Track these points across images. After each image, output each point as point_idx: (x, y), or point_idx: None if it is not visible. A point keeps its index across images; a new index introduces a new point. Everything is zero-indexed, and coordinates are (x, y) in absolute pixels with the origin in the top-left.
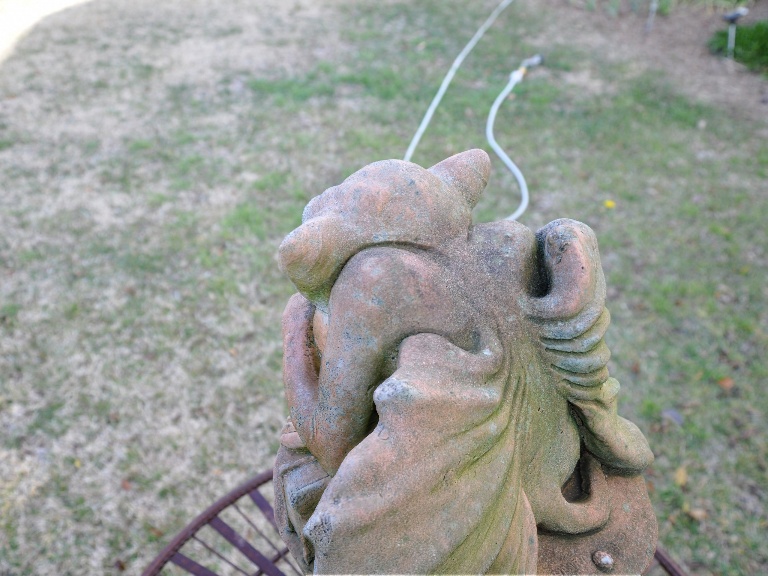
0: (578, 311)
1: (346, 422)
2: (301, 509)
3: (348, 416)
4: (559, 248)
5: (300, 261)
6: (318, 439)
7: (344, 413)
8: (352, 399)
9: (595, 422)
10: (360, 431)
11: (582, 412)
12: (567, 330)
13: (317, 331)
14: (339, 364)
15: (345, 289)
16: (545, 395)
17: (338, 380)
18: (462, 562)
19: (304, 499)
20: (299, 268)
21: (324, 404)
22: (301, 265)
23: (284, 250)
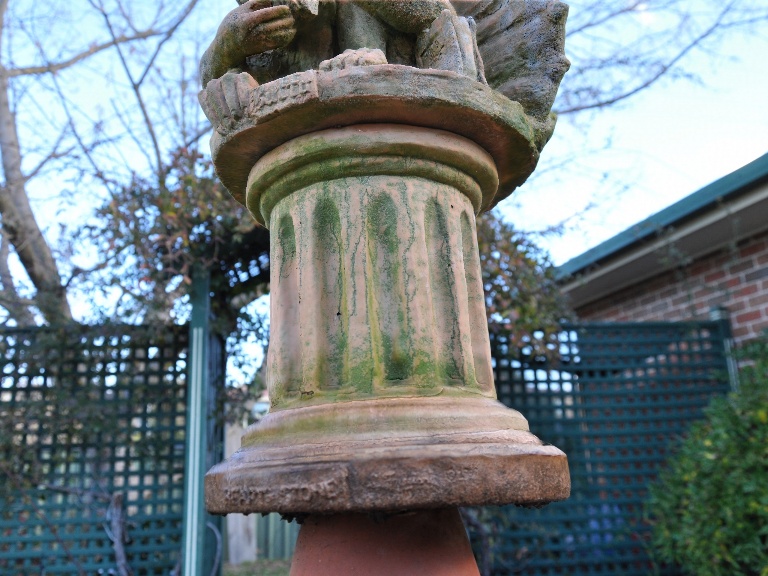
0: None
1: None
2: None
3: None
4: None
5: None
6: None
7: None
8: None
9: None
10: None
11: None
12: None
13: None
14: None
15: None
16: None
17: None
18: None
19: None
20: None
21: None
22: None
23: None
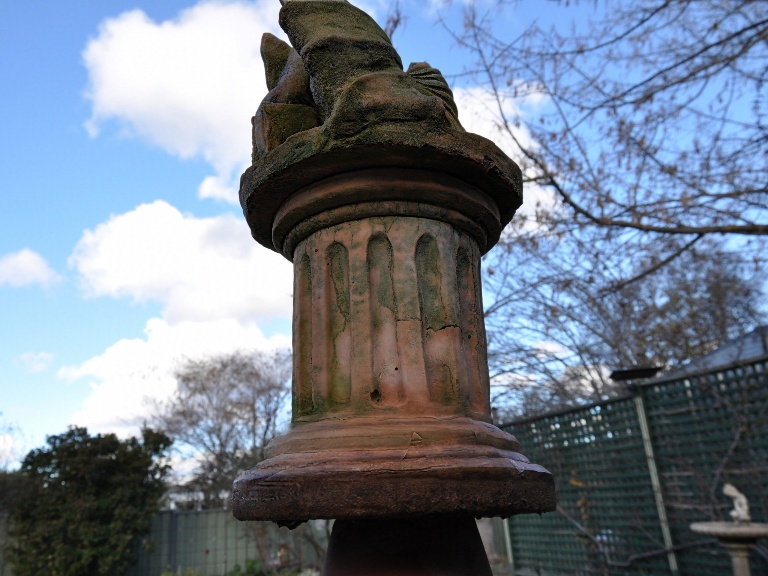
0: (425, 66)
1: (298, 70)
2: (267, 109)
3: (299, 68)
4: (411, 66)
5: (273, 40)
6: (280, 82)
7: (297, 66)
8: None
9: (456, 127)
10: (306, 77)
11: (445, 115)
12: (421, 70)
13: None
14: None
15: None
16: (416, 88)
17: None
18: (368, 25)
19: (270, 104)
20: (272, 44)
21: None
22: (273, 43)
23: (265, 33)
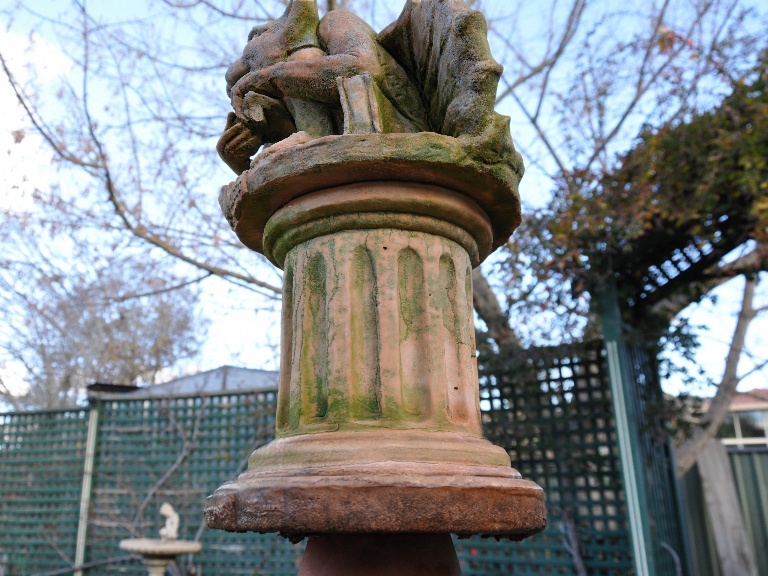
0: None
1: (373, 51)
2: None
3: (373, 49)
4: None
5: None
6: (363, 54)
7: (371, 46)
8: (372, 42)
9: None
10: None
11: None
12: None
13: (303, 57)
14: (356, 29)
15: (339, 10)
16: None
17: (360, 33)
18: None
19: None
20: None
21: (356, 43)
22: None
23: None
